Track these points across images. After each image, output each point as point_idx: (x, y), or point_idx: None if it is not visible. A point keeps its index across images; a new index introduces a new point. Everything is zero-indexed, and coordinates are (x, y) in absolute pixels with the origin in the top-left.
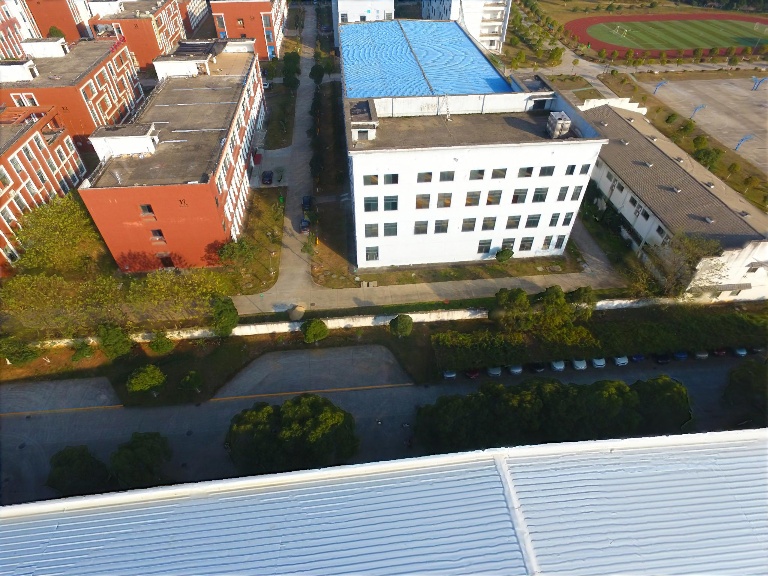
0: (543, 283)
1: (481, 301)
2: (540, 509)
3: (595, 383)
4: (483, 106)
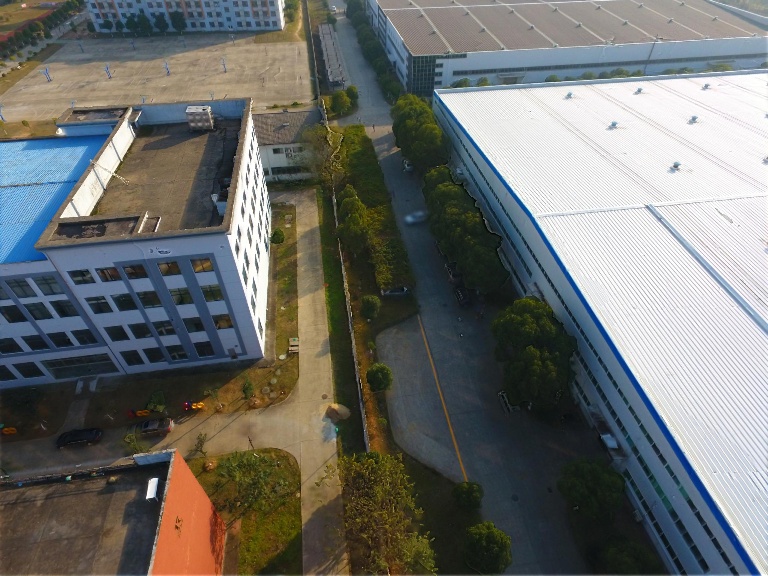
0: (307, 226)
1: (327, 263)
2: (557, 206)
3: (440, 197)
4: (117, 153)
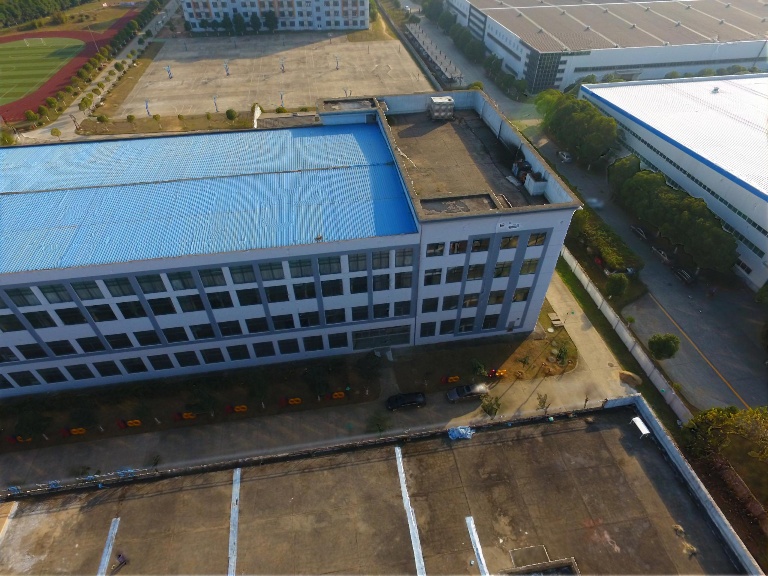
0: None
1: None
2: None
3: (643, 184)
4: None
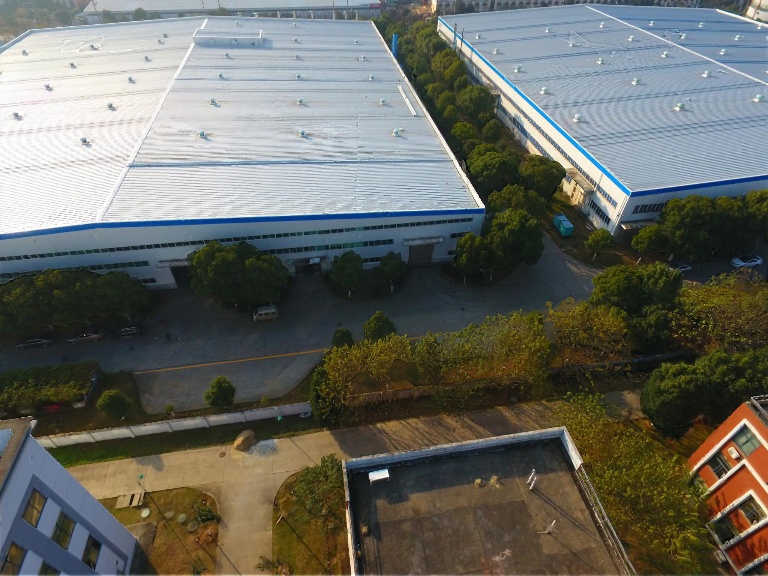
0: None
1: None
2: None
3: None
4: None
